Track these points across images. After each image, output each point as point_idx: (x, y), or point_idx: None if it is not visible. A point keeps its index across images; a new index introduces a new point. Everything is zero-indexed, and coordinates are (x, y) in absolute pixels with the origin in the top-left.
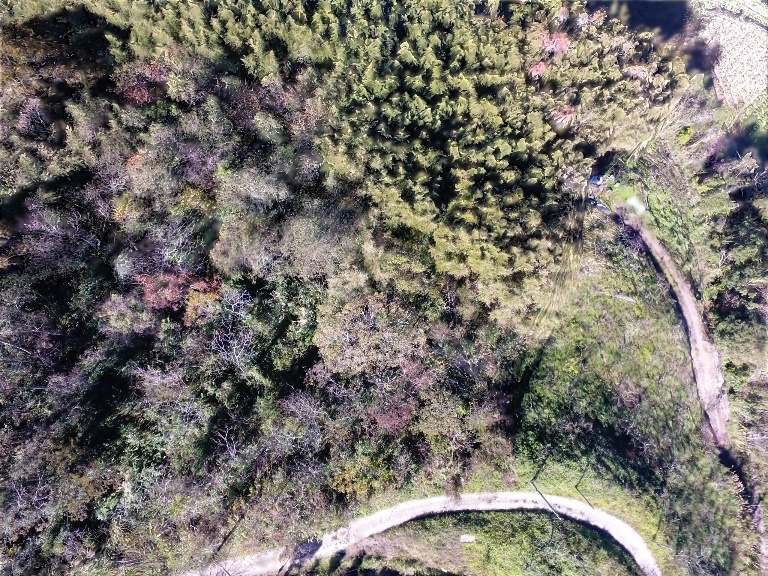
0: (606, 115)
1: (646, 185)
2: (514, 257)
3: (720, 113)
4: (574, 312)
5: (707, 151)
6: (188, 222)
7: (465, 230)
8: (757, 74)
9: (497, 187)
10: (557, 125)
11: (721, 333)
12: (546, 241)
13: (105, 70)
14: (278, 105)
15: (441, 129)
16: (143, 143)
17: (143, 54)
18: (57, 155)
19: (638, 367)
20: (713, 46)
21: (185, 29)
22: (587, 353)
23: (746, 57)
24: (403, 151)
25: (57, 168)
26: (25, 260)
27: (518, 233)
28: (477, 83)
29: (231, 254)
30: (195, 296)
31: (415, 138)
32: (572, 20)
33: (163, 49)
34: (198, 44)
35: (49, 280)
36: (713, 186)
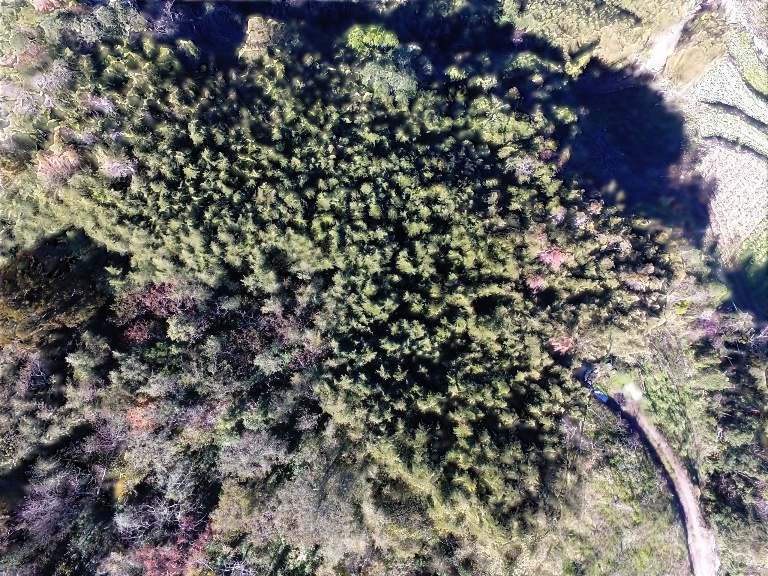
0: (603, 335)
1: (643, 370)
2: (512, 526)
3: (716, 291)
4: (571, 524)
5: (704, 320)
6: (187, 480)
7: (463, 496)
8: (753, 206)
9: (495, 433)
10: (555, 352)
11: (718, 524)
12: (544, 506)
13: (105, 298)
14: (277, 337)
15: (439, 358)
16: (143, 393)
17: (143, 280)
18: (57, 414)
19: (635, 571)
20: (709, 180)
21: (185, 256)
22: (584, 565)
23: (742, 189)
24: (402, 397)
25: (57, 429)
26: (24, 533)
27: (516, 497)
28: (475, 300)
29: (230, 518)
30: (194, 554)
31: (414, 373)
32: (570, 219)
33: (163, 279)
34: (198, 269)
35: (48, 547)
36: (709, 364)
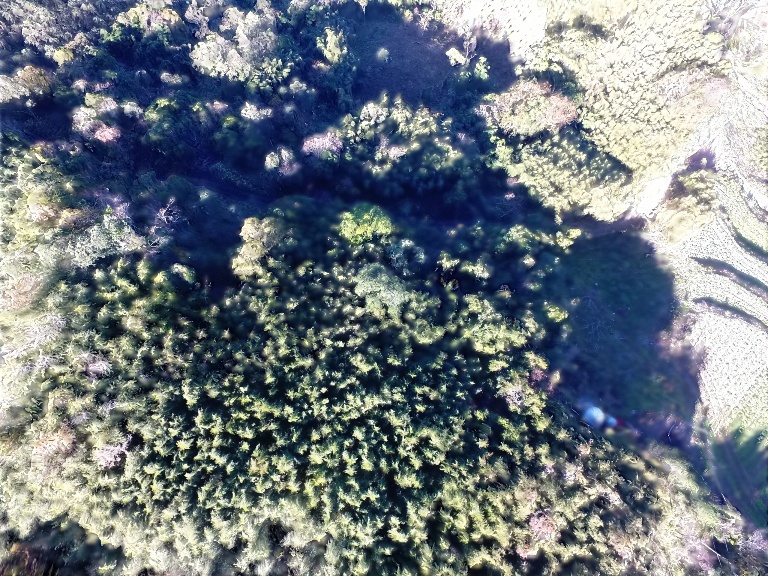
0: None
1: None
2: None
3: (704, 515)
4: None
5: None
6: None
7: None
8: (742, 373)
9: None
10: None
11: None
12: None
13: None
14: None
15: None
16: None
17: (137, 571)
18: None
19: None
20: (699, 348)
21: (179, 549)
22: None
23: (731, 356)
24: None
25: None
26: None
27: None
28: (466, 575)
29: None
30: None
31: None
32: (559, 471)
33: (157, 575)
34: (192, 558)
35: None
36: None
